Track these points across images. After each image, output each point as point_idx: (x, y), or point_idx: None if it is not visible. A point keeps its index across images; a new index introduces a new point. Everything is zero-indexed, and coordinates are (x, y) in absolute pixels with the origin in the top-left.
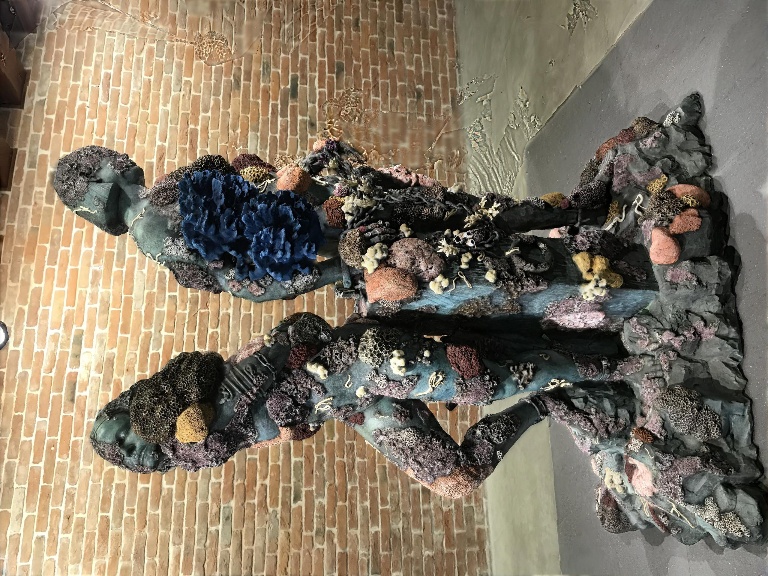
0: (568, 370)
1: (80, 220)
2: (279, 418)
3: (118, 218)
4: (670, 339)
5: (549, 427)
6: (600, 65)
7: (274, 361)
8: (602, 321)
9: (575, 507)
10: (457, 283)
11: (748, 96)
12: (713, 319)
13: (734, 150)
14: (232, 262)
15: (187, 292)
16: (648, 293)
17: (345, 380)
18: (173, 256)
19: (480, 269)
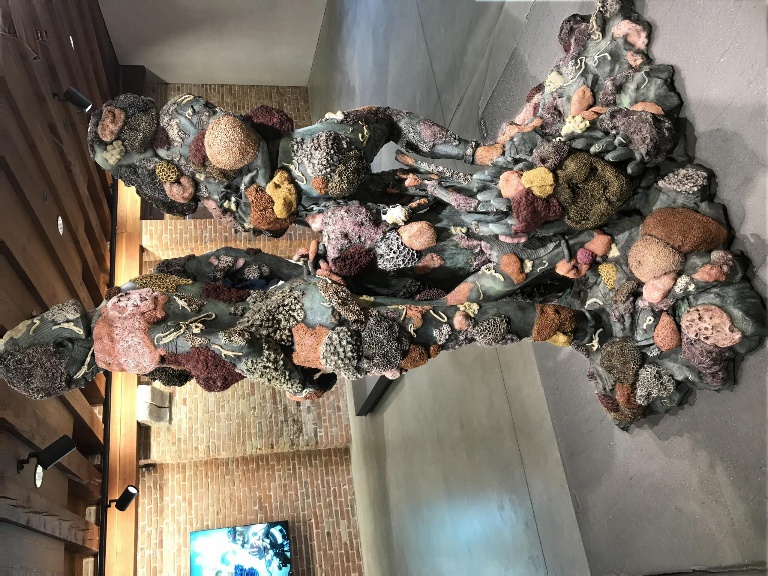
0: None
1: None
2: None
3: None
4: None
5: None
6: None
7: None
8: None
9: None
10: None
11: None
12: None
13: None
14: None
15: None
16: None
17: None
18: None
19: None
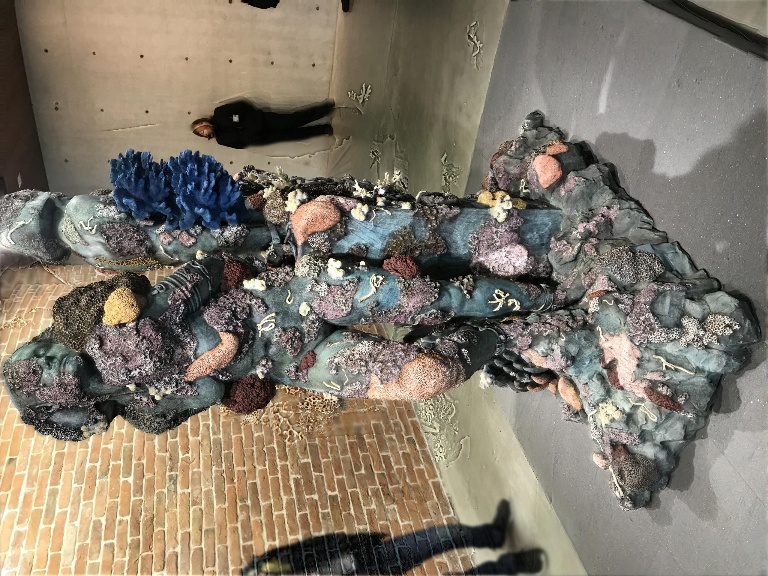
0: (508, 285)
1: (6, 483)
2: (219, 324)
3: (52, 232)
4: (585, 226)
5: (551, 503)
6: (470, 171)
7: (208, 268)
8: (528, 262)
9: (609, 557)
10: (376, 211)
11: (563, 76)
12: (612, 201)
13: (572, 112)
14: (162, 220)
15: (126, 538)
16: (553, 213)
17: (285, 296)
18: (104, 218)
19: (395, 206)
